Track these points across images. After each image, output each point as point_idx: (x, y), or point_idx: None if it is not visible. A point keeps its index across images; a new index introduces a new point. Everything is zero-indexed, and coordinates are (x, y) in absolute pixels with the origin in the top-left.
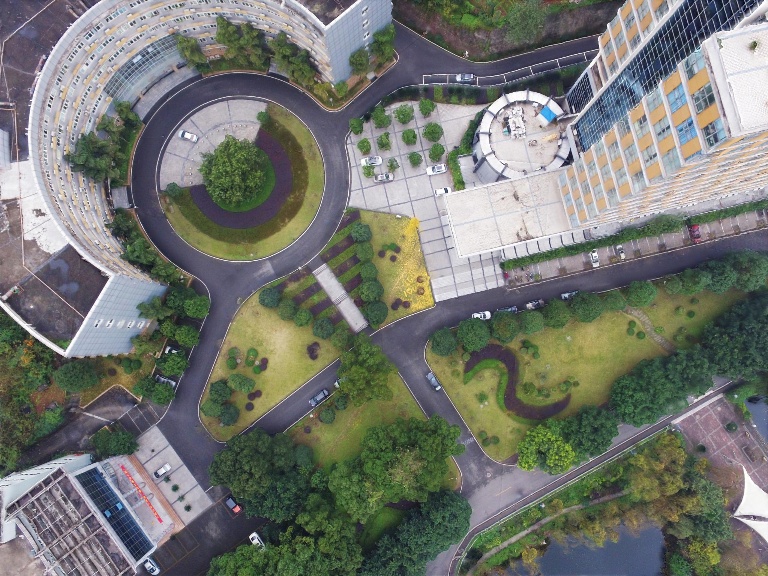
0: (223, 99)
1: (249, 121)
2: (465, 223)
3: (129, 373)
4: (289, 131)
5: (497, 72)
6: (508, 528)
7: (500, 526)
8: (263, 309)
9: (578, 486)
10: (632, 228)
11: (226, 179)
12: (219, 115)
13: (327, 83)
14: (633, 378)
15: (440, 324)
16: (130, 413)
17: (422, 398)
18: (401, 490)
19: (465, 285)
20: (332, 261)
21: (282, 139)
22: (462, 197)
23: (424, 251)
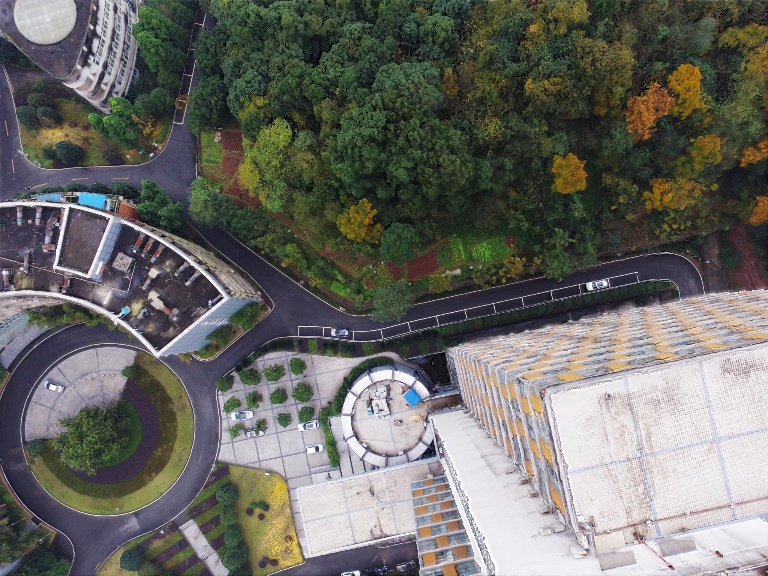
0: (91, 347)
1: (118, 370)
2: (317, 519)
3: None
4: (158, 381)
5: (374, 326)
6: None
7: None
8: None
9: None
10: None
11: (77, 461)
12: (87, 363)
13: None
14: None
15: None
16: None
17: None
18: None
19: None
20: (199, 518)
21: (150, 391)
22: (316, 491)
23: (293, 509)
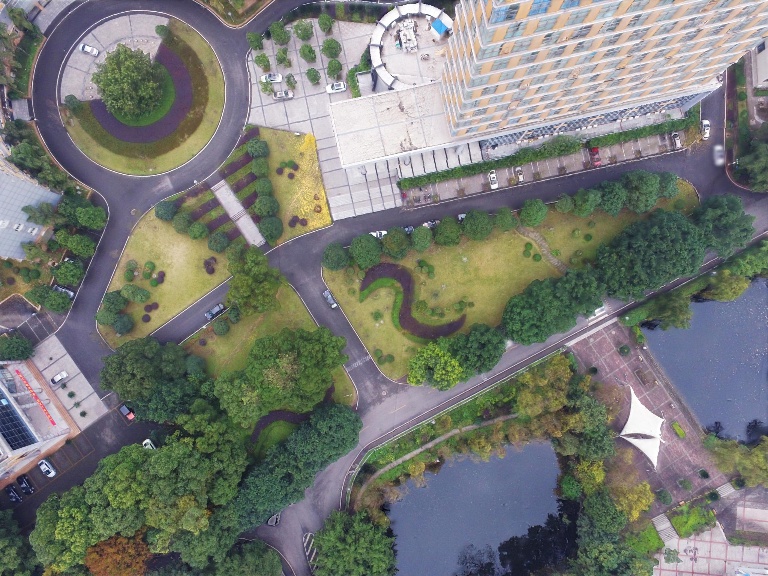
0: (124, 13)
1: (150, 36)
2: (349, 133)
3: (27, 282)
4: (190, 47)
5: None
6: (402, 445)
7: (393, 443)
8: (161, 223)
9: (471, 406)
10: (529, 149)
11: (115, 86)
12: (120, 29)
13: None
14: (523, 297)
15: None
16: (29, 322)
17: (319, 316)
18: (283, 396)
19: (363, 204)
20: (230, 177)
21: (182, 54)
22: (347, 107)
23: (322, 169)
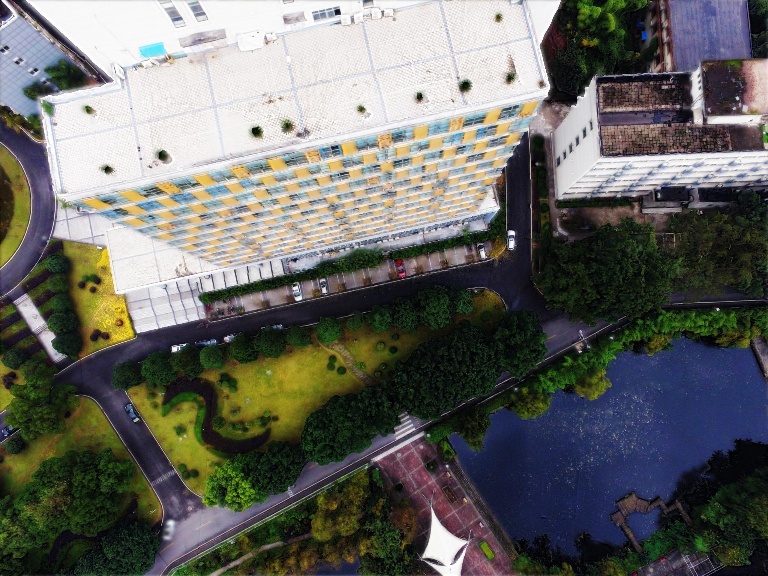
0: None
1: None
2: (124, 258)
3: None
4: None
5: None
6: (206, 563)
7: (197, 561)
8: None
9: (277, 522)
10: (329, 262)
11: None
12: None
13: (17, 116)
14: (318, 415)
15: (140, 356)
16: None
17: (122, 429)
18: (59, 525)
19: (165, 317)
20: (32, 291)
21: None
22: (123, 232)
23: None
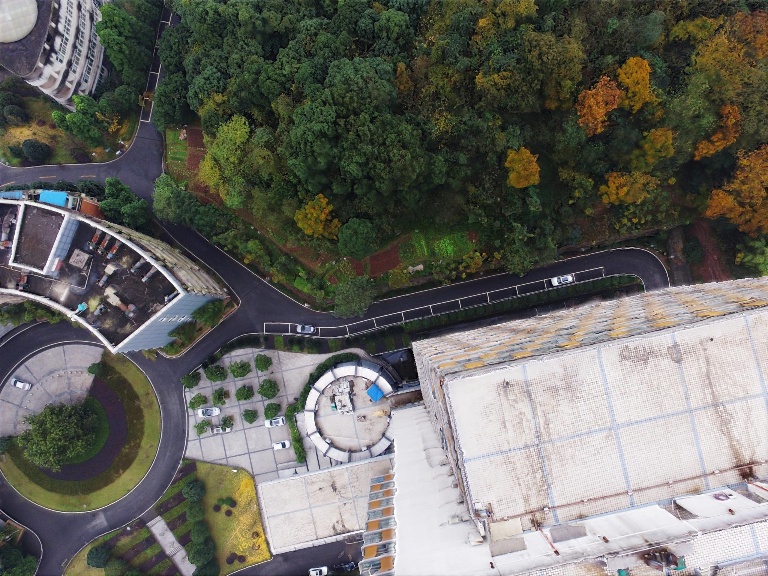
0: (58, 344)
1: (85, 367)
2: (280, 514)
3: None
4: (125, 378)
5: (340, 323)
6: None
7: None
8: None
9: None
10: None
11: (40, 458)
12: (54, 361)
13: None
14: None
15: None
16: None
17: None
18: None
19: None
20: (166, 514)
21: (117, 388)
22: (278, 487)
23: (260, 505)
